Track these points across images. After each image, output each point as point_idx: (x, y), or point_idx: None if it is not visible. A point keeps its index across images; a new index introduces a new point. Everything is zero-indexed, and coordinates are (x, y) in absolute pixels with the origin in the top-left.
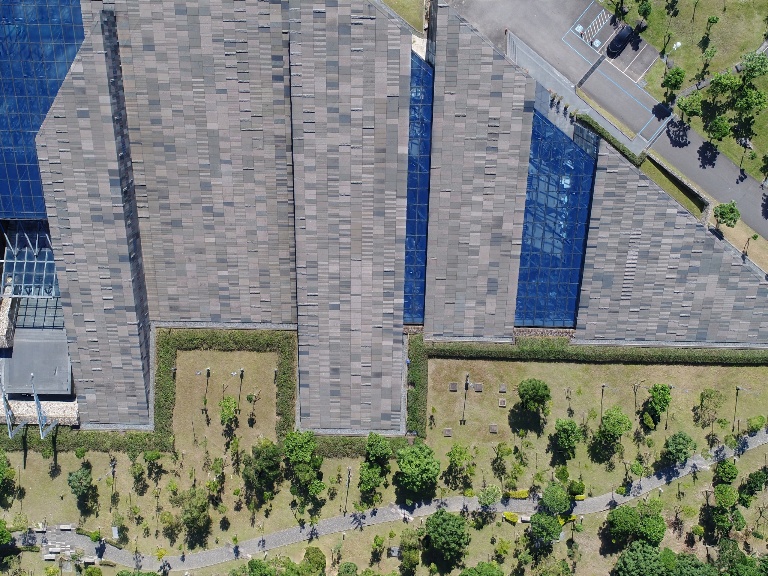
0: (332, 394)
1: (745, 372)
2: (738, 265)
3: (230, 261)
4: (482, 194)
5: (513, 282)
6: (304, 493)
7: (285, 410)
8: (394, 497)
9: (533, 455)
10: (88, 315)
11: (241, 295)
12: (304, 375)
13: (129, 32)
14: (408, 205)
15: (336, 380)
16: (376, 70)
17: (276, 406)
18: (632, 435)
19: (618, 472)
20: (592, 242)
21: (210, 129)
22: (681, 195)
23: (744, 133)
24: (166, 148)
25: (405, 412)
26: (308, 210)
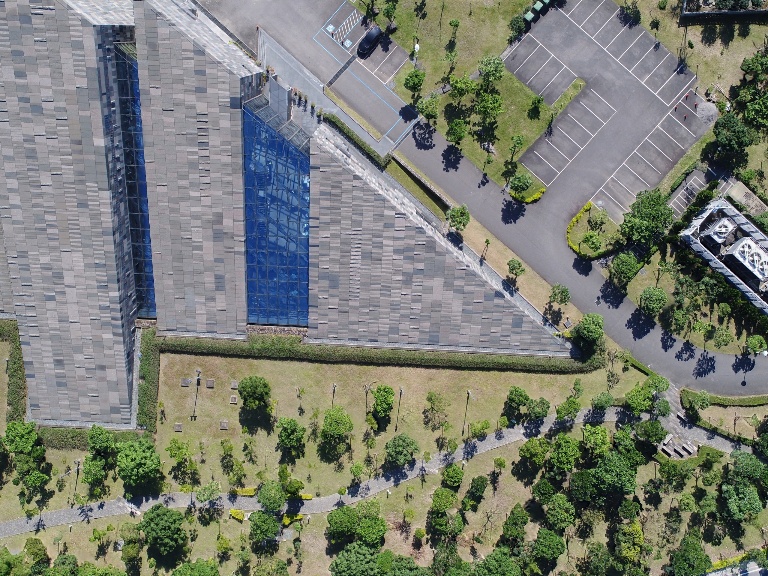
0: (59, 385)
1: (477, 376)
2: (462, 269)
3: None
4: (199, 189)
5: (240, 279)
6: None
7: (14, 400)
8: (122, 491)
9: (263, 453)
10: None
11: None
12: (29, 365)
13: None
14: (129, 198)
15: (61, 371)
16: (62, 61)
17: (7, 396)
18: (362, 436)
19: (347, 472)
20: (314, 241)
21: None
22: (426, 198)
23: (487, 137)
24: None
25: (136, 406)
26: (12, 199)
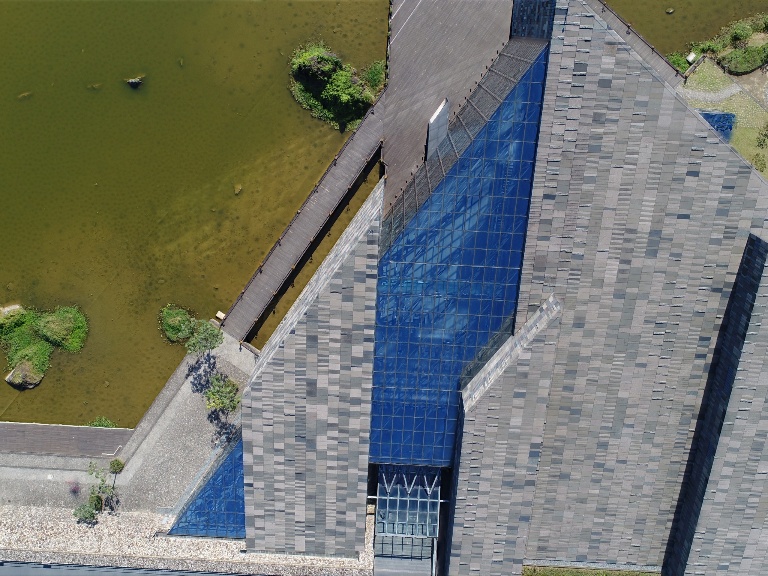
0: None
1: None
2: None
3: (609, 510)
4: None
5: None
6: None
7: None
8: None
9: None
10: (474, 565)
11: (612, 540)
12: None
13: (562, 311)
14: None
15: None
16: None
17: None
18: None
19: None
20: None
21: (620, 397)
22: None
23: None
24: (572, 411)
25: None
26: (721, 484)
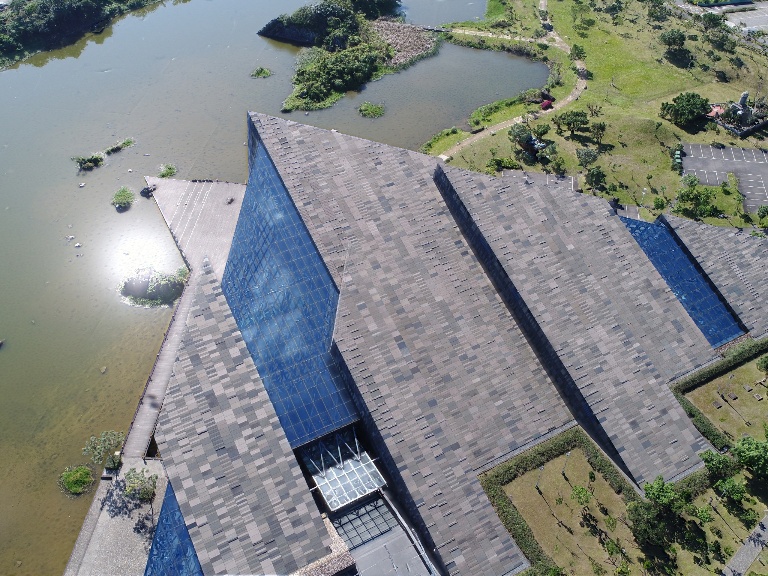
0: (645, 447)
1: None
2: None
3: (499, 391)
4: (626, 270)
5: (687, 317)
6: (696, 546)
7: (621, 483)
8: (763, 505)
9: None
10: (424, 470)
11: (521, 416)
12: (615, 440)
13: None
14: None
15: (640, 432)
16: (527, 211)
17: (611, 487)
18: None
19: None
20: (708, 271)
21: (438, 301)
22: None
23: (717, 213)
24: (415, 326)
25: (704, 439)
26: (539, 308)
